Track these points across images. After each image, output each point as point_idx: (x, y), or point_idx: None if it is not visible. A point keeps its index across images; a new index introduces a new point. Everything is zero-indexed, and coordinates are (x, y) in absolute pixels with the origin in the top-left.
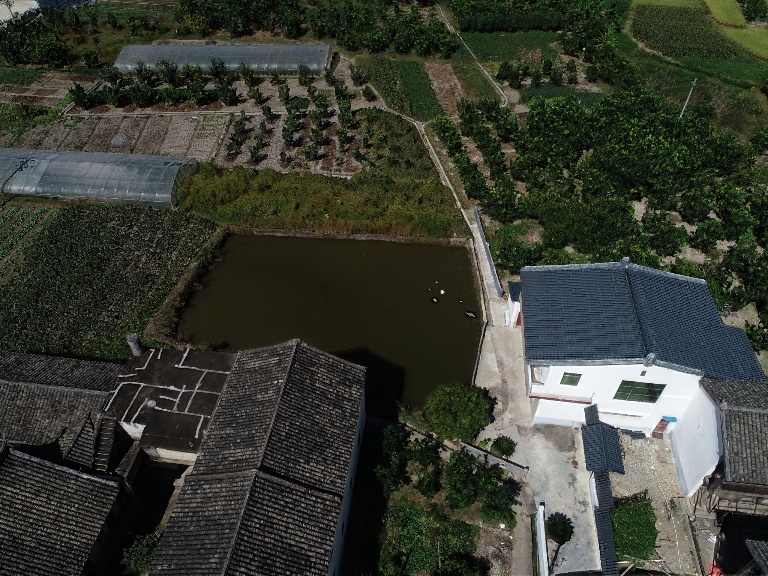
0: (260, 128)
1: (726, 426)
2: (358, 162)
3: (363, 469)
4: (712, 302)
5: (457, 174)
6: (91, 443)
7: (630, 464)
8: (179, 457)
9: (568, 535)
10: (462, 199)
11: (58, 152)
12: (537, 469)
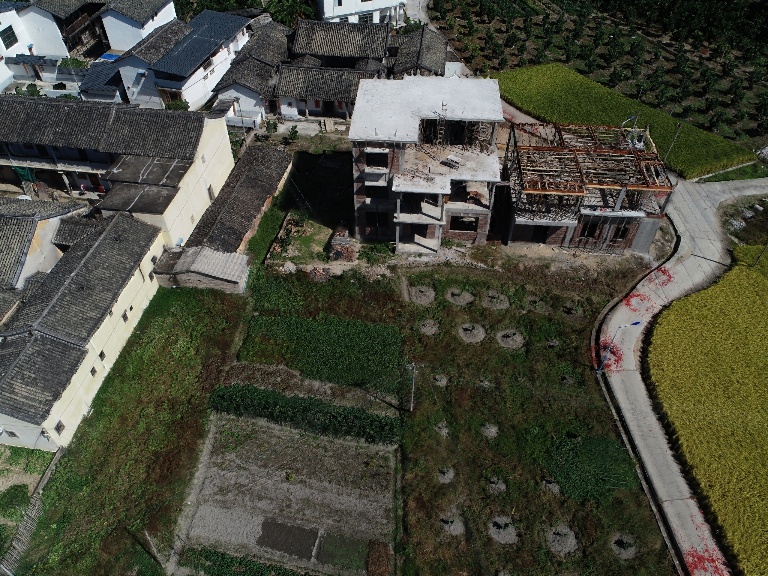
0: None
1: (41, 7)
2: None
3: None
4: None
5: None
6: None
7: None
8: None
9: (63, 84)
10: None
11: None
12: None
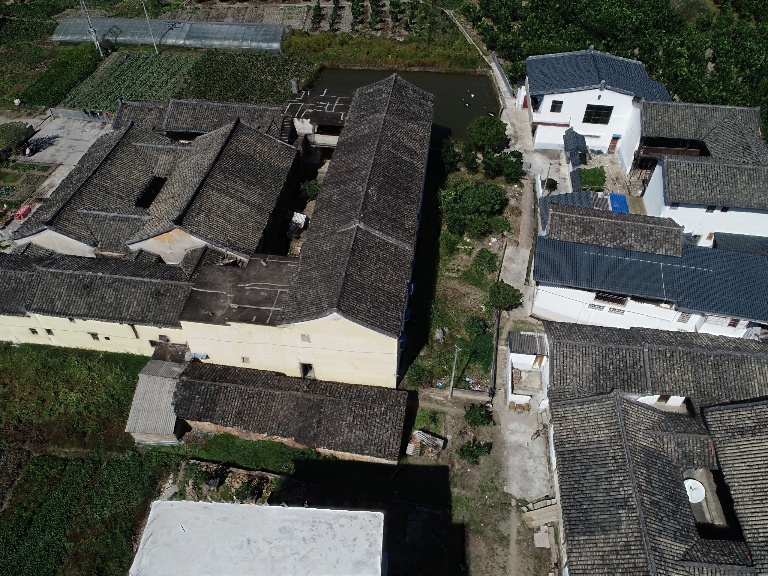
0: (333, 12)
1: (644, 110)
2: (407, 32)
3: (431, 164)
4: (645, 71)
5: (479, 38)
6: (277, 132)
7: (593, 164)
8: (327, 141)
9: (554, 183)
10: (483, 51)
11: (193, 21)
12: (536, 166)
